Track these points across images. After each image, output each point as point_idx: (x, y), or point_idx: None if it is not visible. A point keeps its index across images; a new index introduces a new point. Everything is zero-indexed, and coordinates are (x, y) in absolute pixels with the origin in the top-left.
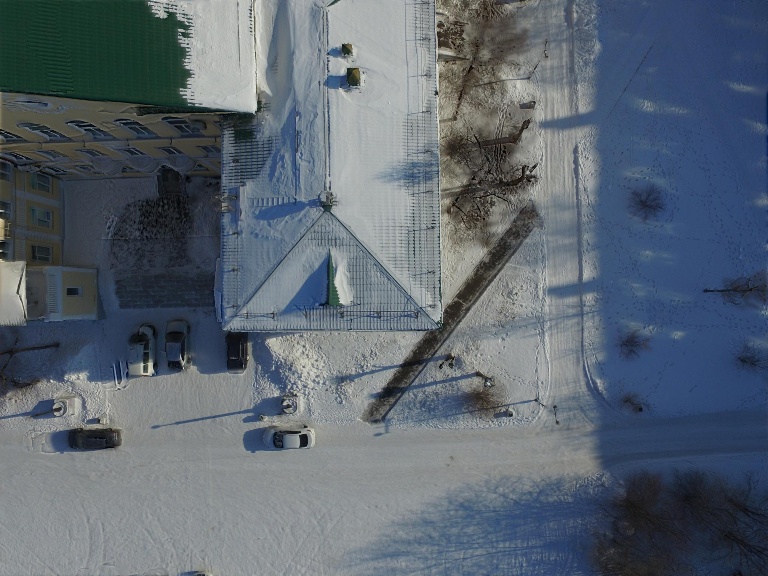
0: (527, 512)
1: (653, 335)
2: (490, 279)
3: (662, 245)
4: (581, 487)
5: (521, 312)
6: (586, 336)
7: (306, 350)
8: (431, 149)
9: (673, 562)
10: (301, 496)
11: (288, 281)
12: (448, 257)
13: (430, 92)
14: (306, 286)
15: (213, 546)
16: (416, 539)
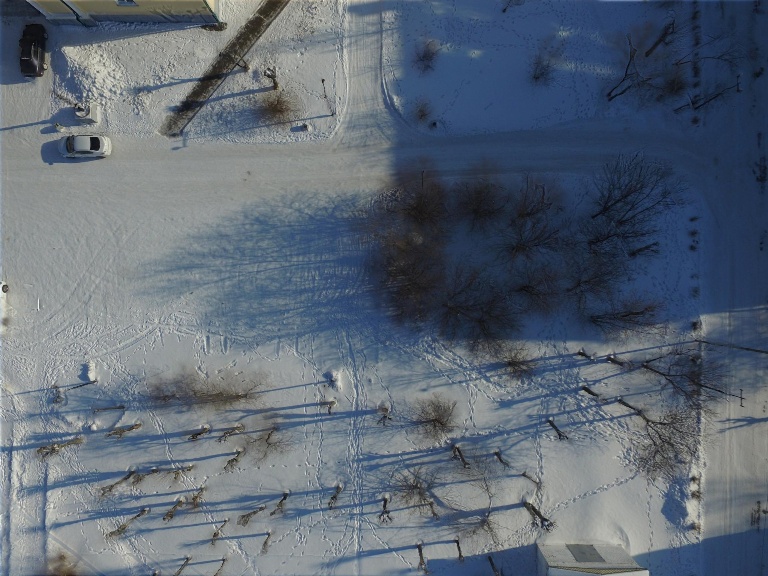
0: (322, 227)
1: (450, 52)
2: None
3: None
4: (375, 203)
5: (320, 27)
6: (385, 53)
7: (103, 59)
8: None
9: (461, 274)
10: (97, 208)
11: None
12: None
13: None
14: None
15: (8, 256)
16: (211, 252)
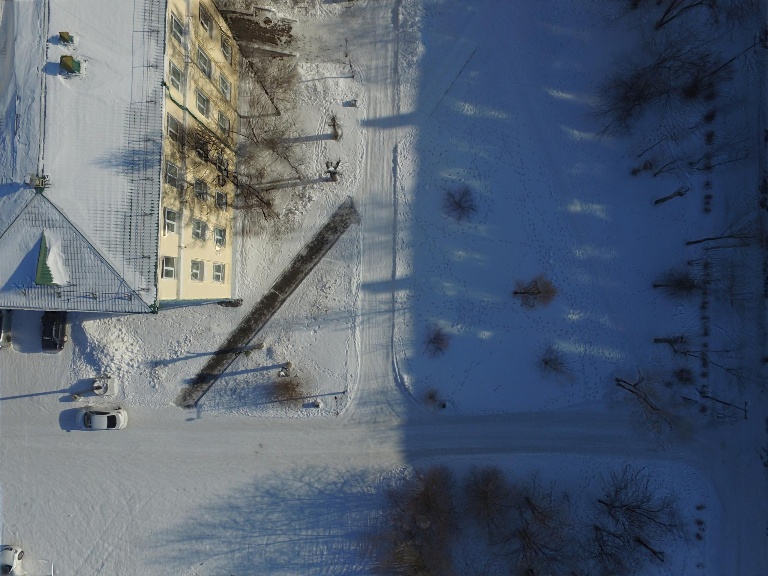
0: (331, 502)
1: (461, 334)
2: (306, 272)
3: (475, 246)
4: (384, 479)
5: (334, 306)
6: (396, 332)
7: (122, 334)
8: (154, 138)
9: (468, 556)
10: (112, 476)
11: (6, 259)
12: (266, 249)
13: (156, 83)
14: (23, 265)
15: (24, 521)
16: (221, 523)
